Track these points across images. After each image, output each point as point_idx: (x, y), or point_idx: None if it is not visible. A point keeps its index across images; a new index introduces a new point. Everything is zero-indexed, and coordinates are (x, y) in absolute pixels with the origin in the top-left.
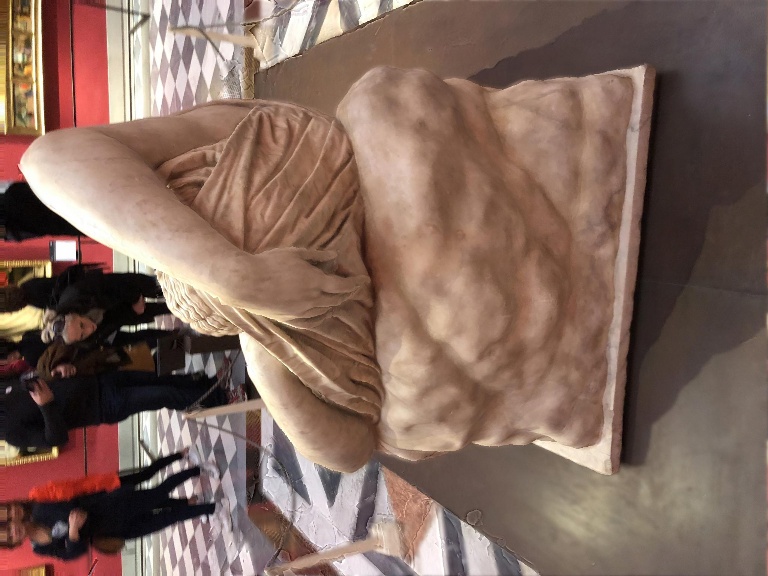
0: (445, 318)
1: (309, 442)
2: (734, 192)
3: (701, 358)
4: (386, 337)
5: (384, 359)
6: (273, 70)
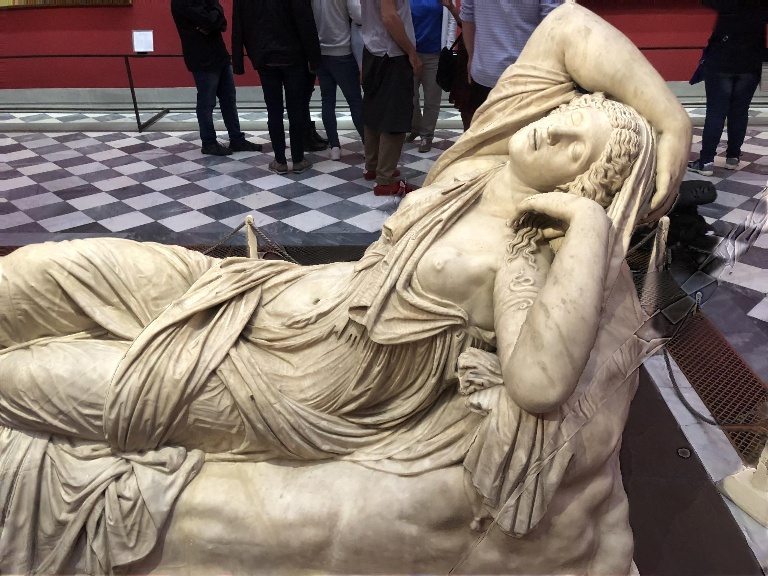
0: (639, 307)
1: (598, 296)
2: (639, 429)
3: (666, 521)
4: (613, 290)
5: (611, 302)
6: None
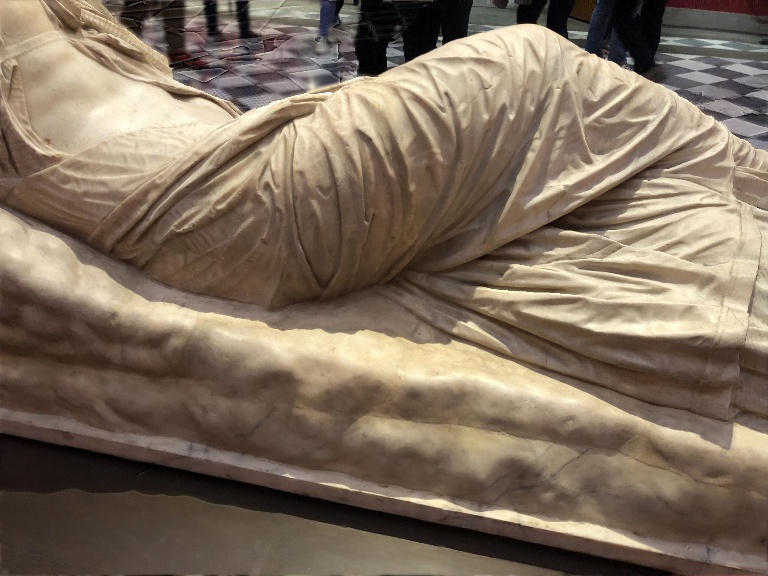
0: None
1: None
2: None
3: None
4: None
5: None
6: None
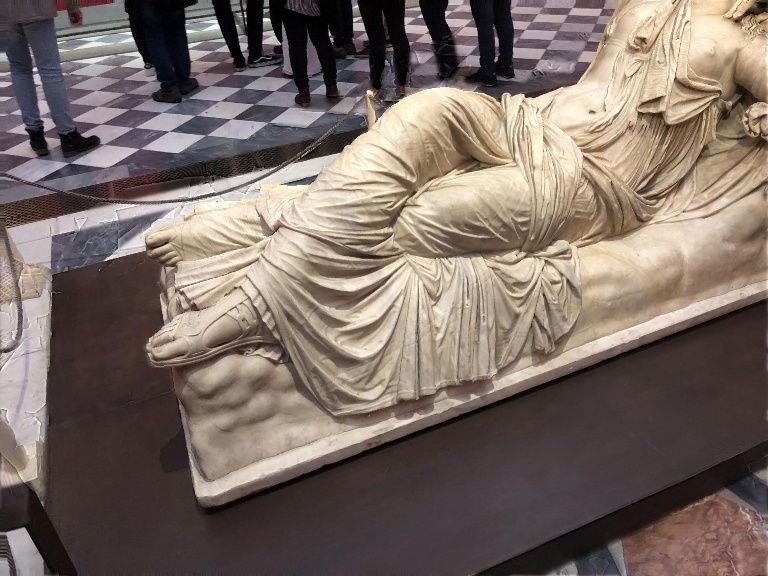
0: None
1: None
2: None
3: None
4: None
5: None
6: (134, 256)
